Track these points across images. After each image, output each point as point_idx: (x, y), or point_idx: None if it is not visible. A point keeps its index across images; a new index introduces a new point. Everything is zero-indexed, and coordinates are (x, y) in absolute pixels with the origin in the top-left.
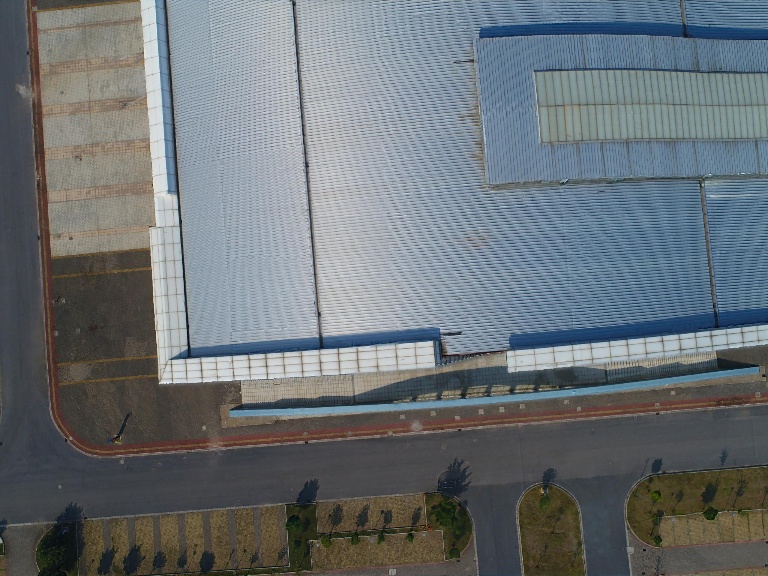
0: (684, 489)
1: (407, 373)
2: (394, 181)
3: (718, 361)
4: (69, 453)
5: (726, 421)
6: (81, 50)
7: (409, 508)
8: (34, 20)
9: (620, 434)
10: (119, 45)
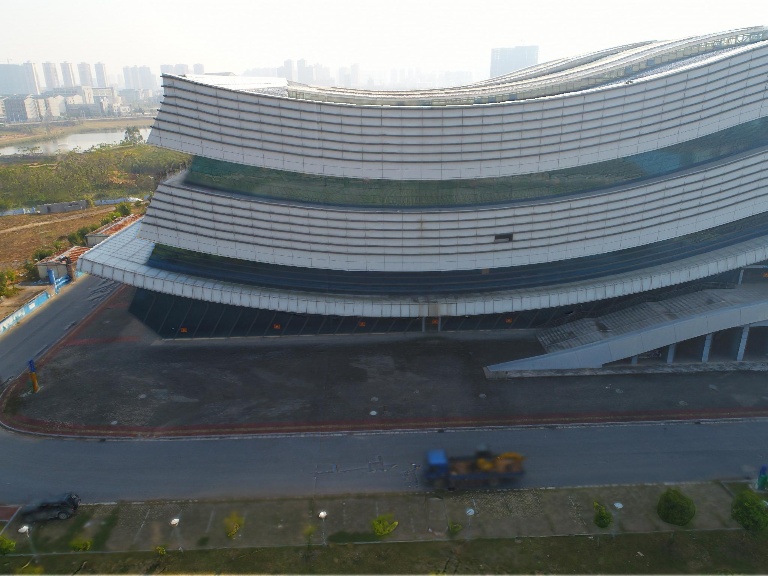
0: None
1: None
2: None
3: None
4: None
5: None
6: None
7: None
8: None
9: None
10: None
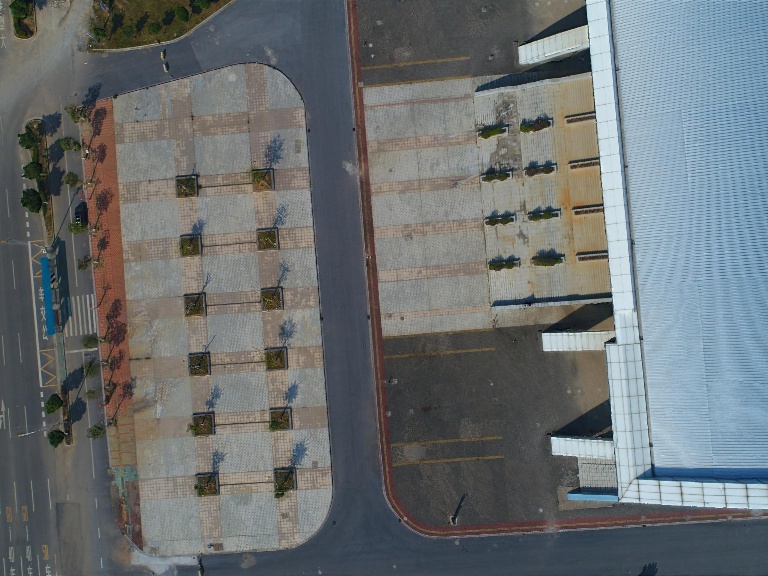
0: None
1: None
2: None
3: None
4: (403, 533)
5: None
6: (410, 127)
7: None
8: (360, 96)
9: None
10: (449, 123)
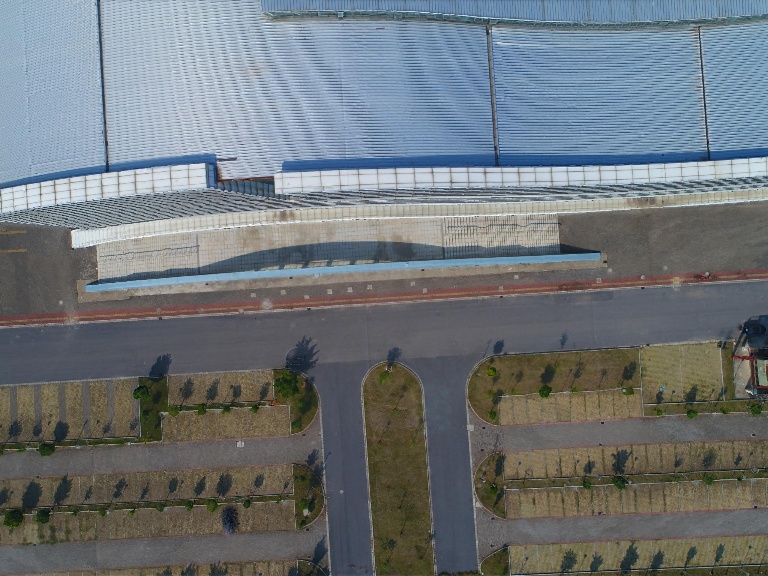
0: (524, 370)
1: (251, 247)
2: (177, 12)
3: (561, 247)
4: None
5: (567, 305)
6: None
7: (258, 383)
8: None
9: (464, 316)
10: None
